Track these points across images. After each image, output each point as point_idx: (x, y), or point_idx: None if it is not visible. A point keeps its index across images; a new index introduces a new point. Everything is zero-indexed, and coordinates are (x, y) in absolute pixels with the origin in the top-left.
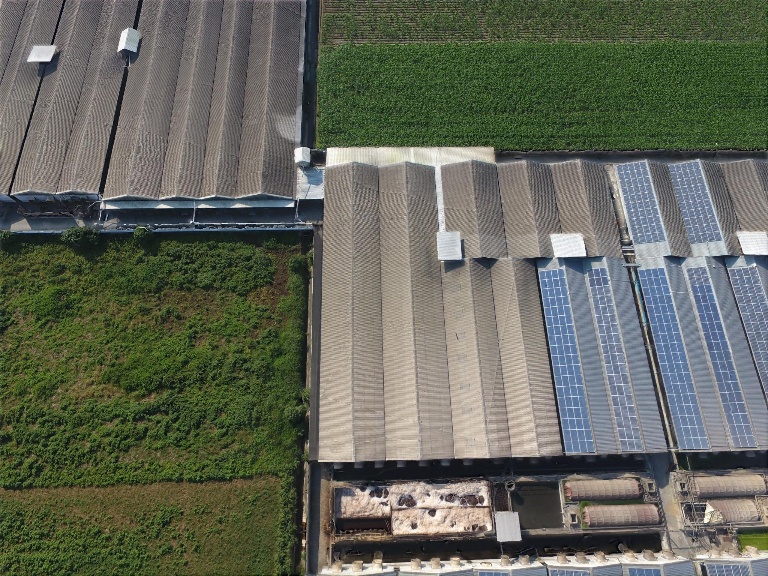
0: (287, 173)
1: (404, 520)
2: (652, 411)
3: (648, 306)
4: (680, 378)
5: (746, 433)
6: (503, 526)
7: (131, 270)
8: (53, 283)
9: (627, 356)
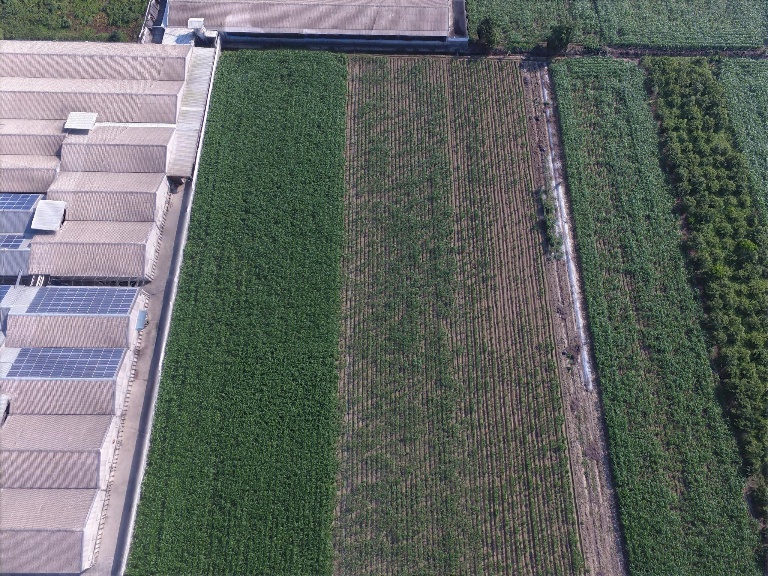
0: None
1: None
2: None
3: None
4: None
5: None
6: None
7: None
8: None
9: None
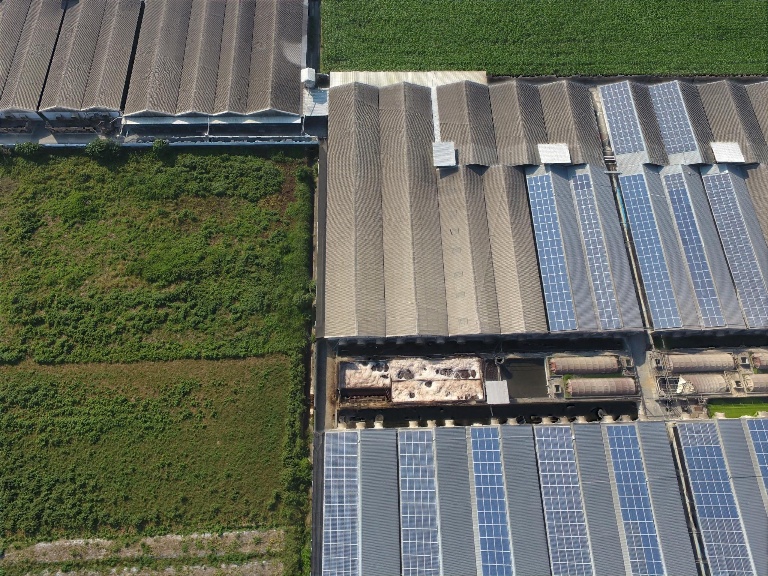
0: (294, 93)
1: (403, 390)
2: (630, 296)
3: (628, 208)
4: (656, 268)
5: (716, 314)
6: (493, 391)
7: (150, 179)
8: (79, 190)
9: (607, 249)
